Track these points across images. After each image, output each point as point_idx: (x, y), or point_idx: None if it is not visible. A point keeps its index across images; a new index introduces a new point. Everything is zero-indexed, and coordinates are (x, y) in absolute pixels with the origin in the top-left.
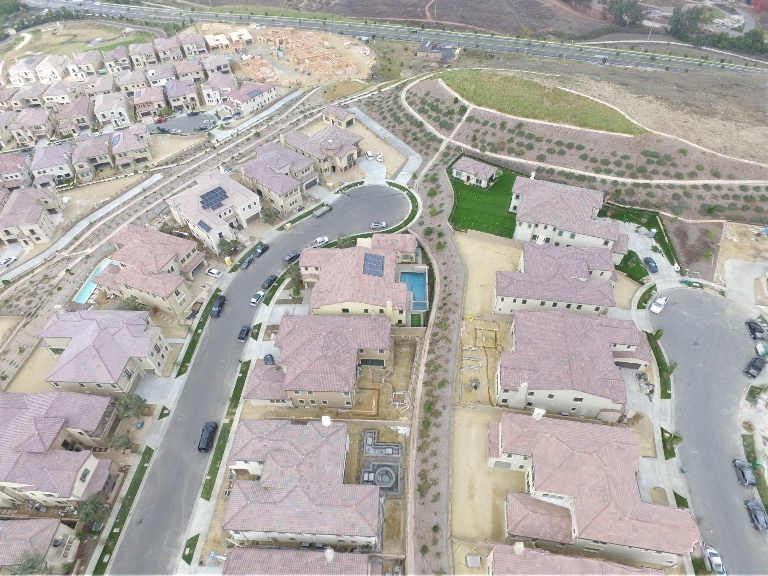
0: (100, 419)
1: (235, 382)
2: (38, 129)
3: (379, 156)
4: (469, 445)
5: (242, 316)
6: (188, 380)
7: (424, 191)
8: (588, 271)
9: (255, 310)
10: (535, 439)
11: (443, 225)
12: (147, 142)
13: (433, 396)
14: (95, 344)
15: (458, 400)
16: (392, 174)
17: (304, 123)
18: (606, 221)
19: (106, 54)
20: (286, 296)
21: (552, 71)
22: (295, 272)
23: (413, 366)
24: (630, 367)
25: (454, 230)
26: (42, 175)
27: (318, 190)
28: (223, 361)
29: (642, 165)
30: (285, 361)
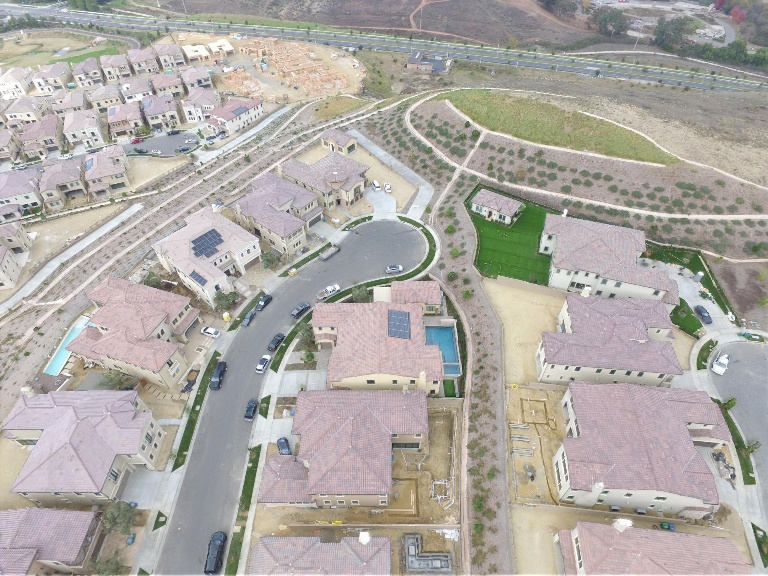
0: (81, 544)
1: (244, 475)
2: (0, 151)
3: (387, 187)
4: (534, 556)
5: (247, 387)
6: (187, 474)
7: (441, 227)
8: (646, 331)
9: (262, 378)
10: (624, 560)
11: (468, 270)
12: (124, 166)
13: (482, 489)
14: (72, 441)
15: (514, 495)
16: (403, 207)
17: (300, 147)
18: (646, 262)
19: (75, 66)
20: (297, 360)
21: (567, 92)
22: (307, 332)
23: (453, 447)
24: (704, 445)
25: (482, 276)
26: (5, 205)
27: (323, 227)
28: (228, 447)
29: (678, 198)
30: (306, 454)
